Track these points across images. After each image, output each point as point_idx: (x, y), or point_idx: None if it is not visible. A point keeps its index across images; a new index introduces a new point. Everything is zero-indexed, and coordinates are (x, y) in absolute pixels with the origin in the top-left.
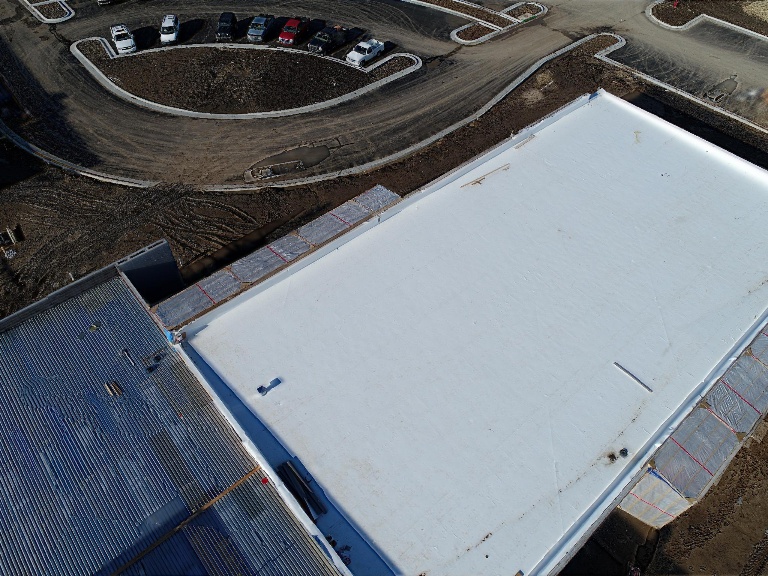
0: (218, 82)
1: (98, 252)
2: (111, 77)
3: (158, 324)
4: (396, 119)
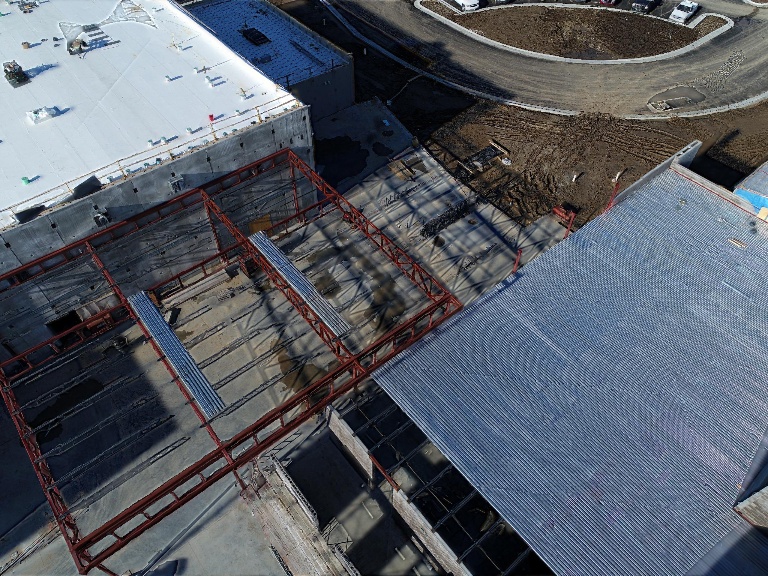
0: (567, 34)
1: (576, 162)
2: (472, 29)
3: (739, 200)
4: (744, 66)
